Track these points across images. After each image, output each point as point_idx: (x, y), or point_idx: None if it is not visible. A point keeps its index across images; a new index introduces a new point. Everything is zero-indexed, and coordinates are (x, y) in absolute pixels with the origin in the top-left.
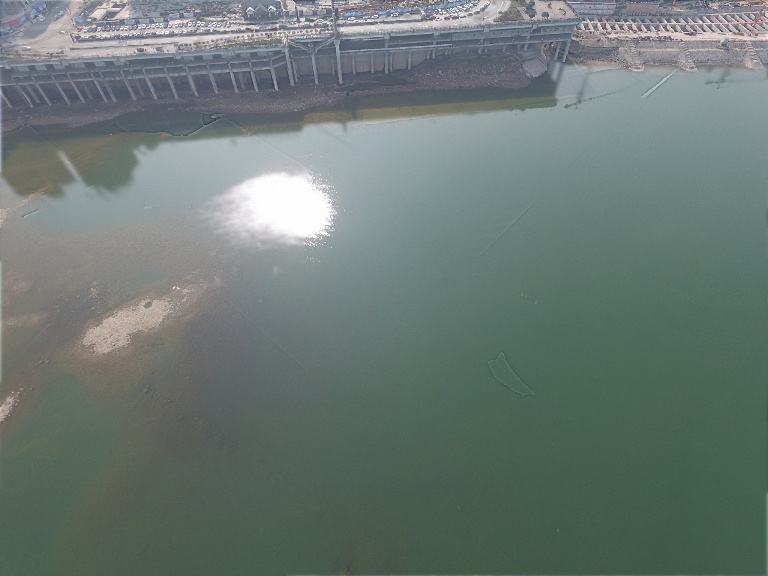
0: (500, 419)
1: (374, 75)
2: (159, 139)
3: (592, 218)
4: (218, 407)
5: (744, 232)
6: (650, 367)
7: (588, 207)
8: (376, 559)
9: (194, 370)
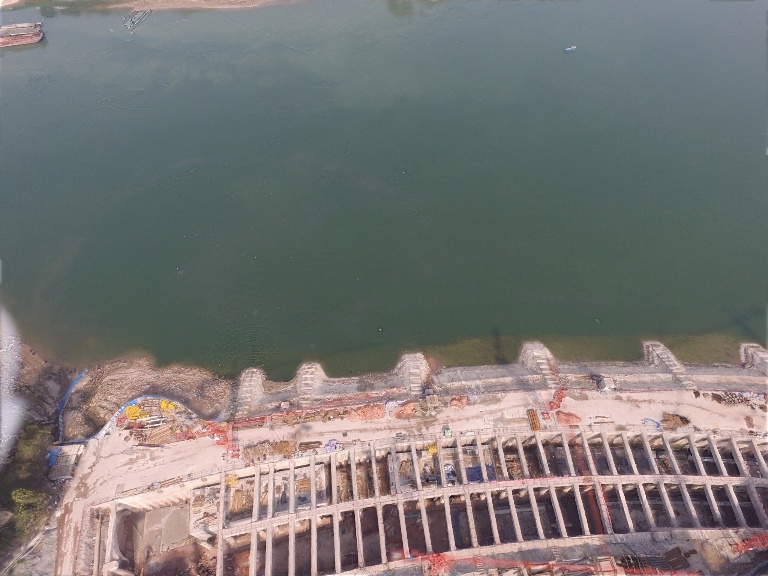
0: None
1: None
2: None
3: (755, 134)
4: None
5: (634, 118)
6: (695, 72)
7: None
8: None
9: None
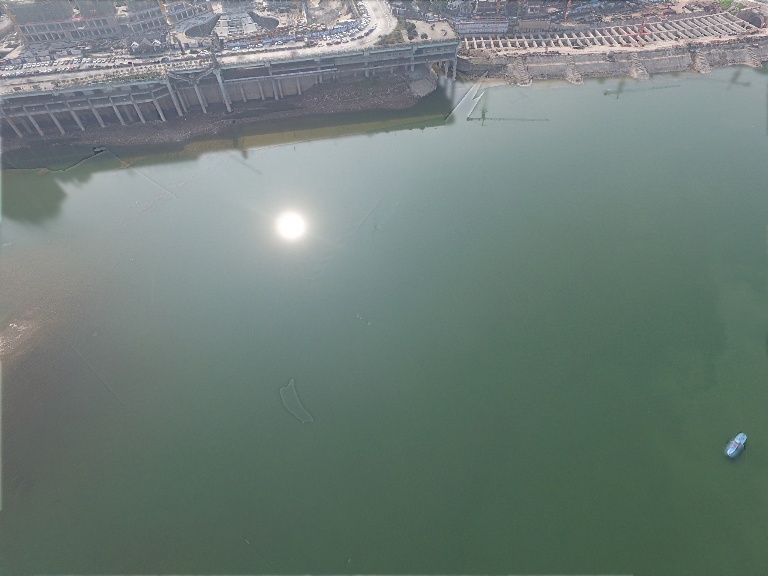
0: (309, 446)
1: (264, 102)
2: (36, 175)
3: (448, 235)
4: (24, 447)
5: (593, 242)
6: (475, 384)
7: (445, 224)
8: None
9: (9, 409)
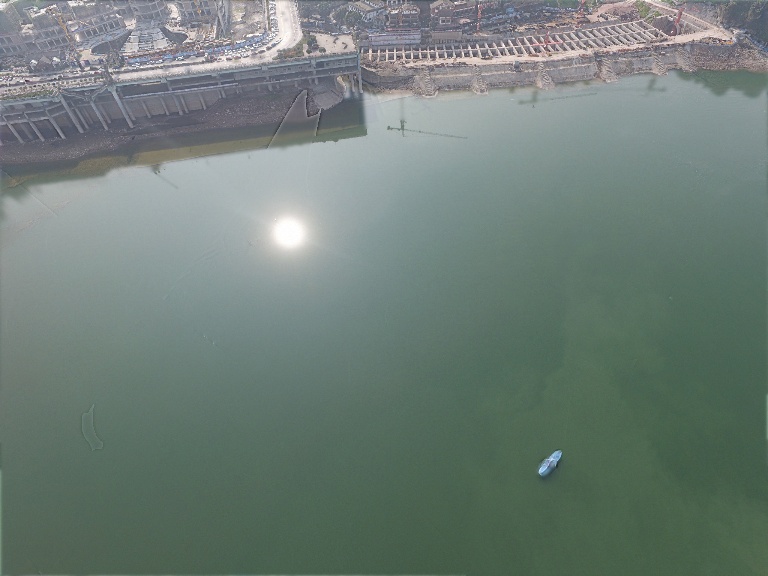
0: (124, 471)
1: (168, 117)
2: None
3: (318, 250)
4: None
5: (457, 256)
6: (310, 404)
7: (316, 239)
8: None
9: None
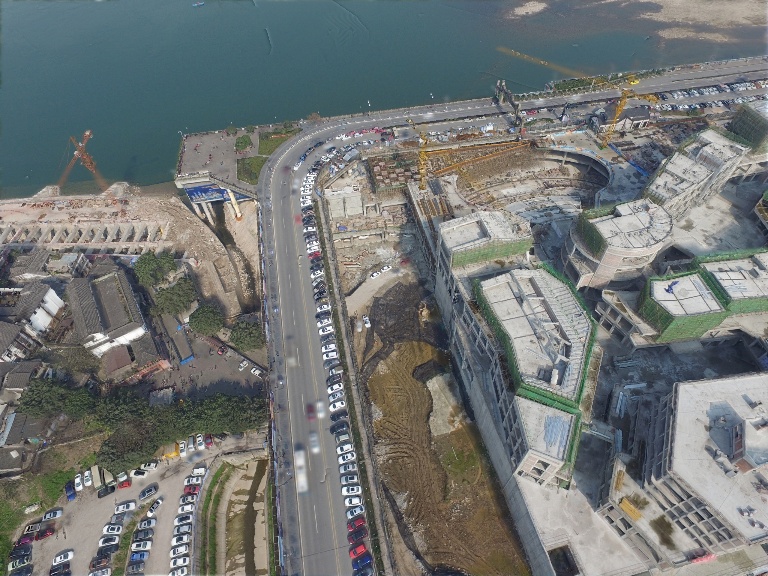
0: (357, 1)
1: None
2: None
3: None
4: None
5: (191, 49)
6: None
7: None
8: None
9: (487, 1)
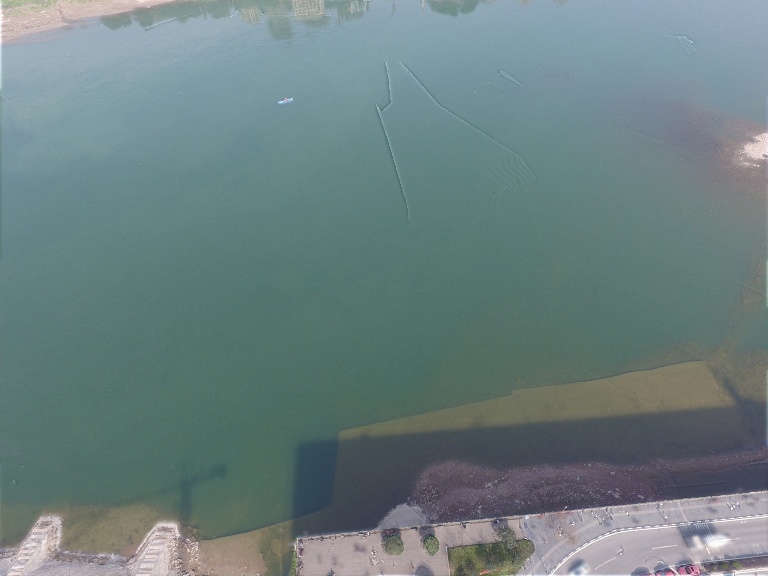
0: (503, 110)
1: None
2: None
3: (406, 215)
4: (665, 114)
5: (280, 193)
6: None
7: (408, 221)
8: (558, 80)
9: (695, 126)
